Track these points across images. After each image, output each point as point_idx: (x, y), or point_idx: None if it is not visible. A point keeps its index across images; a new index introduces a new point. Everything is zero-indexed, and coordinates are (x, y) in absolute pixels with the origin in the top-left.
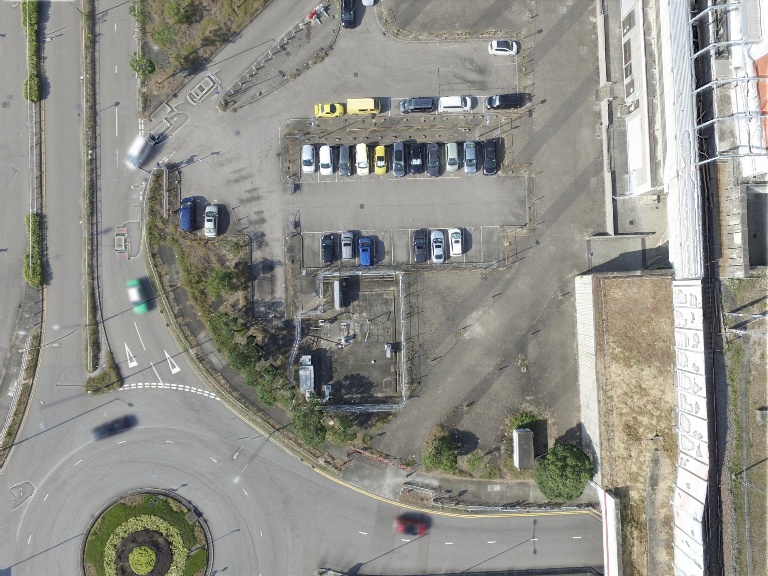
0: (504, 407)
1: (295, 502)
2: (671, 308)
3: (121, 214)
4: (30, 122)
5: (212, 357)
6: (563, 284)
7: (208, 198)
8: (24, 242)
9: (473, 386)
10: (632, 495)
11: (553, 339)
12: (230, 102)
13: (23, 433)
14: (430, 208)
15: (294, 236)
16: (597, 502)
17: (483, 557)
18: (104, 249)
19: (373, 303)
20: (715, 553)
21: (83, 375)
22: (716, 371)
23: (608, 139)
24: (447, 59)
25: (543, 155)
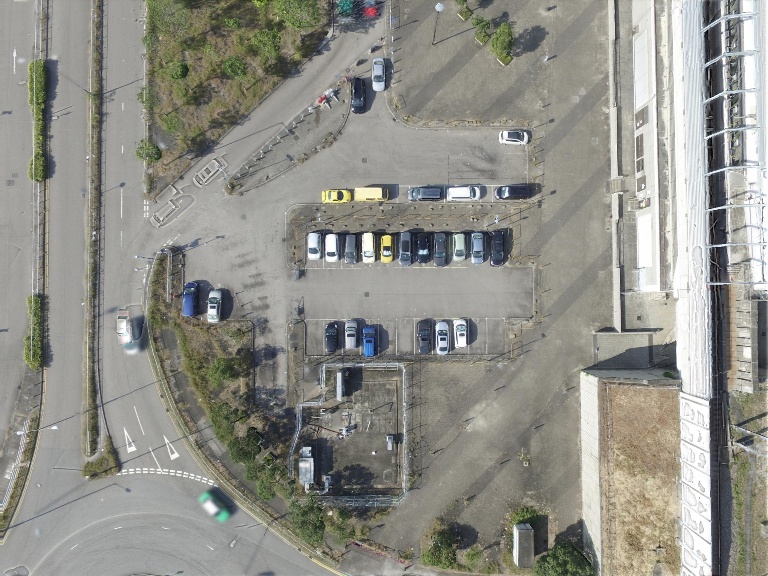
0: (505, 501)
1: None
2: (677, 419)
3: (124, 296)
4: (34, 201)
5: (212, 444)
6: (568, 378)
7: (212, 282)
8: (25, 323)
9: (474, 479)
10: None
11: (556, 434)
12: (236, 185)
13: (19, 516)
14: (436, 298)
15: (297, 323)
16: None
17: None
18: (106, 332)
19: (375, 393)
20: None
21: (81, 459)
22: (721, 484)
23: (618, 234)
24: (457, 147)
25: (551, 247)
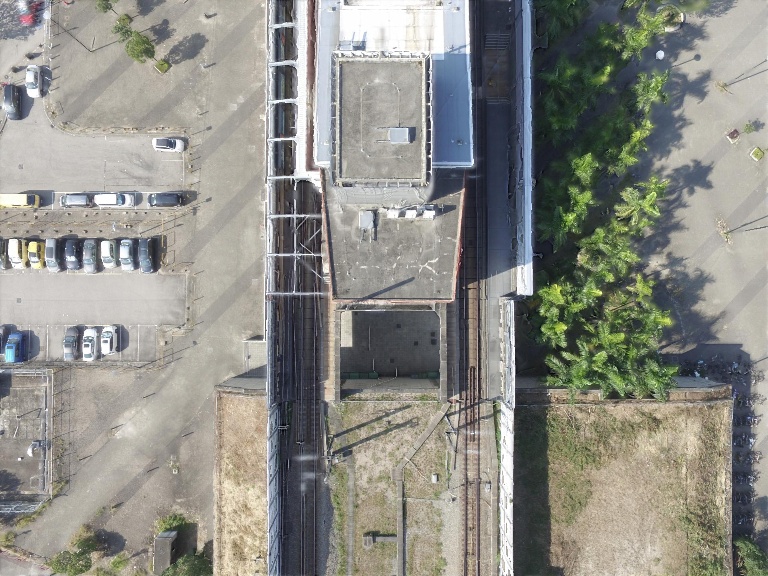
0: (154, 509)
1: None
2: None
3: None
4: None
5: None
6: None
7: None
8: None
9: (122, 486)
10: None
11: (206, 442)
12: None
13: None
14: (88, 304)
15: None
16: None
17: None
18: None
19: (24, 399)
20: None
21: None
22: (318, 495)
23: None
24: (114, 153)
25: (205, 254)
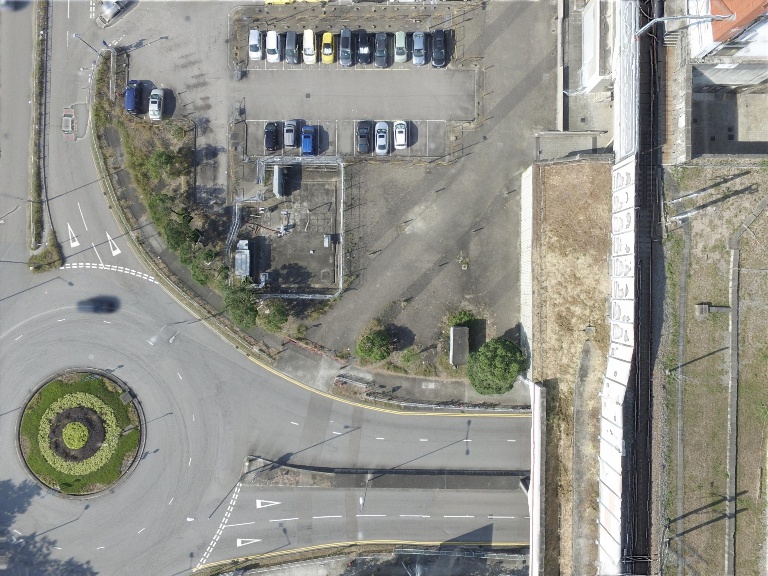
0: (443, 304)
1: (228, 389)
2: (609, 194)
3: (69, 95)
4: None
5: (152, 240)
6: (509, 182)
7: (155, 82)
8: None
9: (412, 281)
10: (562, 388)
11: (496, 237)
12: None
13: None
14: (377, 100)
15: (238, 123)
16: (529, 398)
17: (414, 454)
18: (51, 129)
19: (314, 193)
20: (643, 448)
21: (26, 252)
22: (654, 261)
23: (562, 32)
24: None
25: (495, 49)
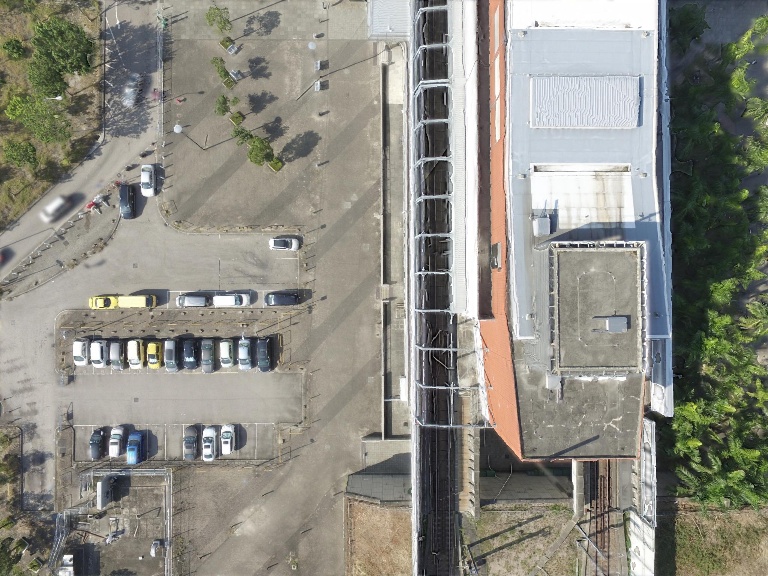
0: None
1: None
2: (409, 540)
3: None
4: None
5: None
6: (336, 483)
7: None
8: None
9: None
10: None
11: (324, 538)
12: (5, 291)
13: None
14: (205, 403)
15: (65, 429)
16: None
17: None
18: None
19: (143, 498)
20: None
21: None
22: None
23: (383, 341)
24: (228, 252)
25: (321, 352)
